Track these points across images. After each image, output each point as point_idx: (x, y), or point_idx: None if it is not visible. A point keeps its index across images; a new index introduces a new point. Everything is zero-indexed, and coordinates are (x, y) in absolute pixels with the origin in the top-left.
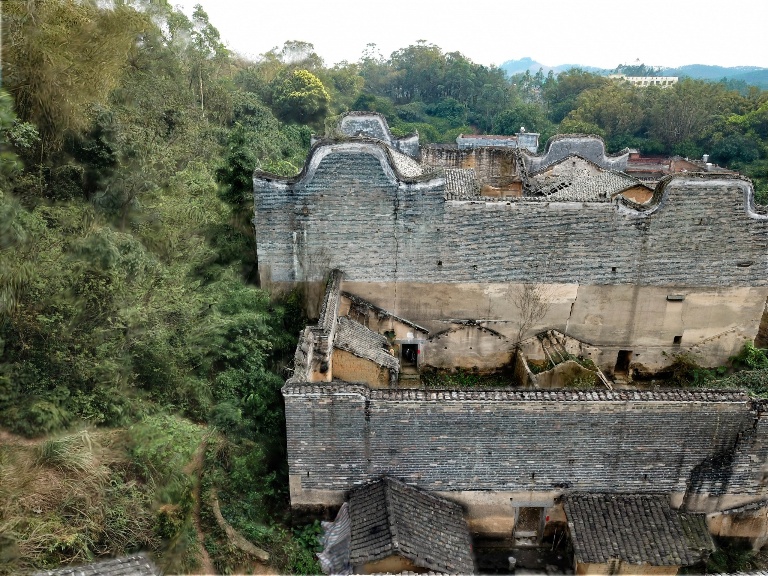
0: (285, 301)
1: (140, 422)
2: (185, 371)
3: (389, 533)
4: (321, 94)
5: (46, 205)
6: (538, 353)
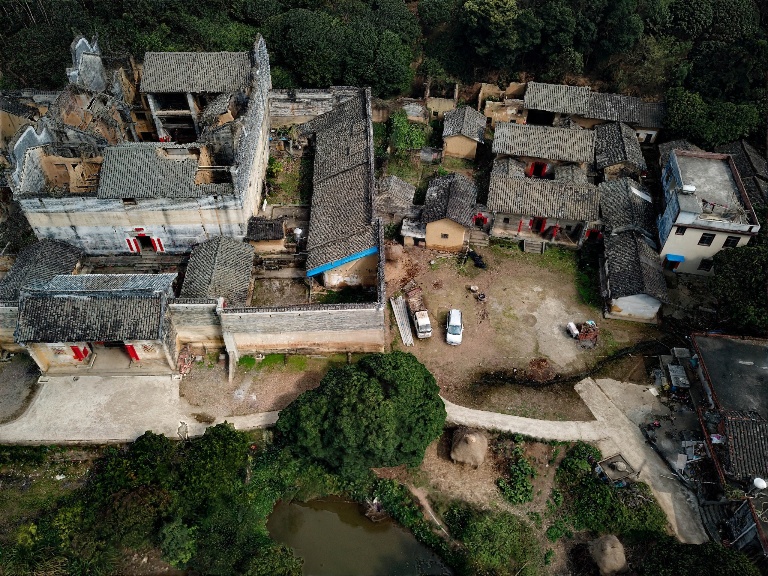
0: None
1: None
2: None
3: None
4: (488, 13)
5: (114, 17)
6: None
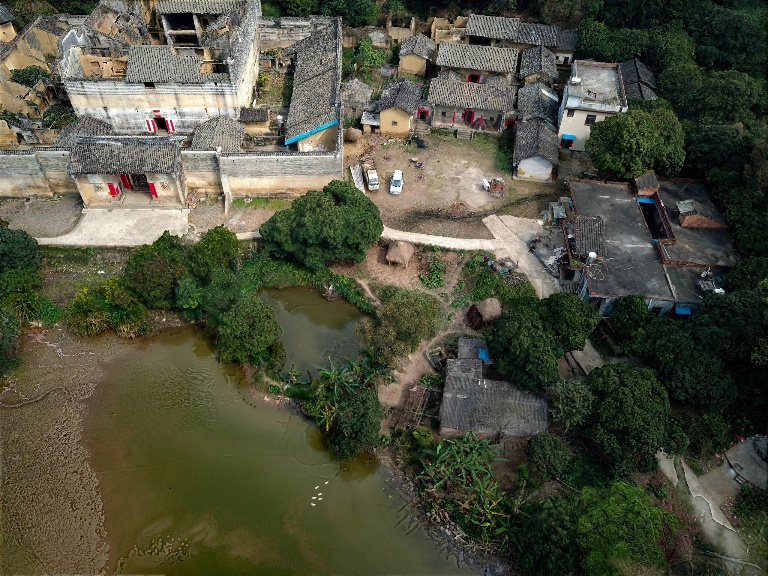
0: None
1: (42, 7)
2: (71, 10)
3: None
4: None
5: None
6: None
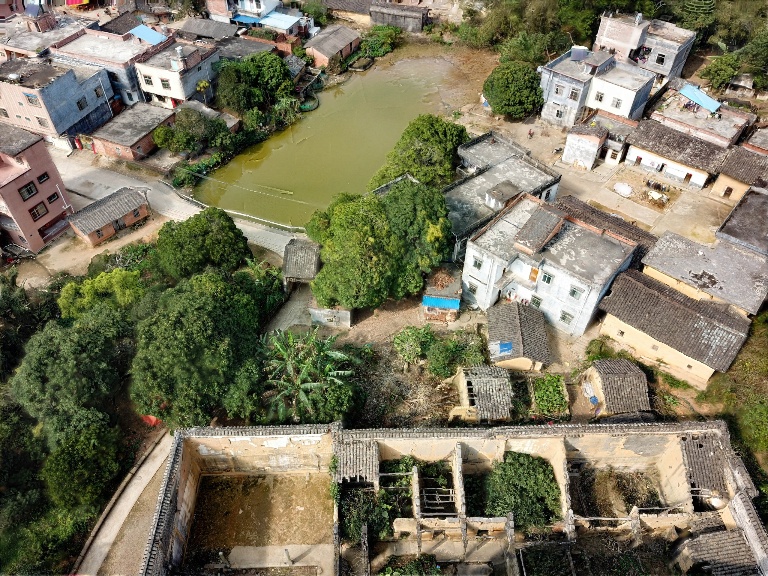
0: None
1: None
2: None
3: None
4: None
5: None
6: None
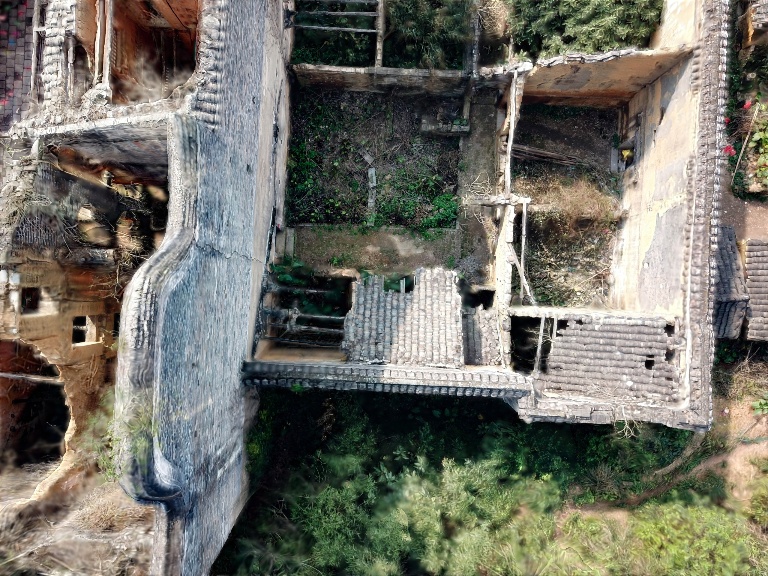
0: (254, 458)
1: None
2: None
3: (729, 303)
4: None
5: None
6: (288, 37)
